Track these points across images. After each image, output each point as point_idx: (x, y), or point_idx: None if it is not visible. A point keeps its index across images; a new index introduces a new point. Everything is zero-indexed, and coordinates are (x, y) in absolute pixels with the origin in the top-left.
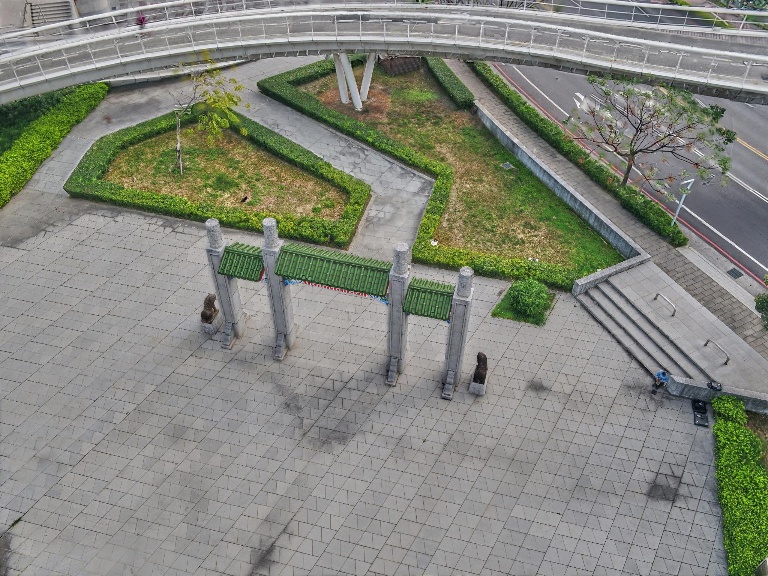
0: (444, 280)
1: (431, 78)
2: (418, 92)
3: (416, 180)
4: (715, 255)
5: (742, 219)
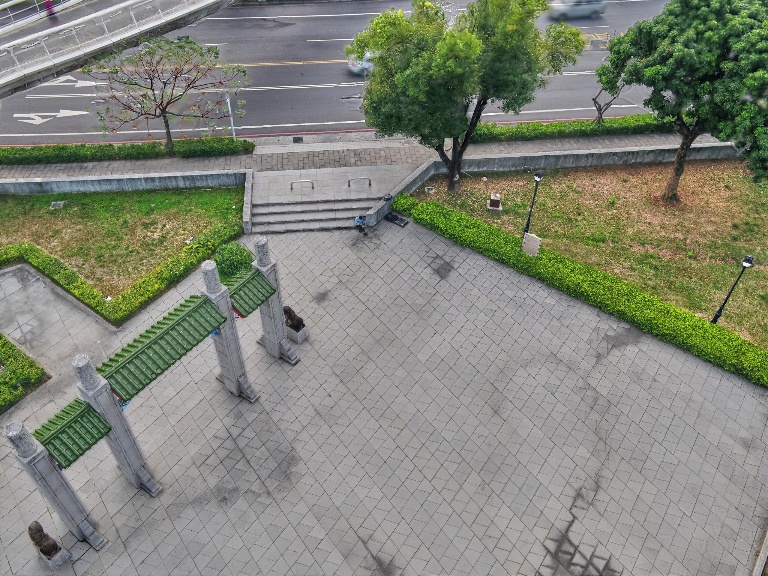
0: (162, 311)
1: None
2: None
3: (4, 279)
4: (274, 139)
5: (253, 109)
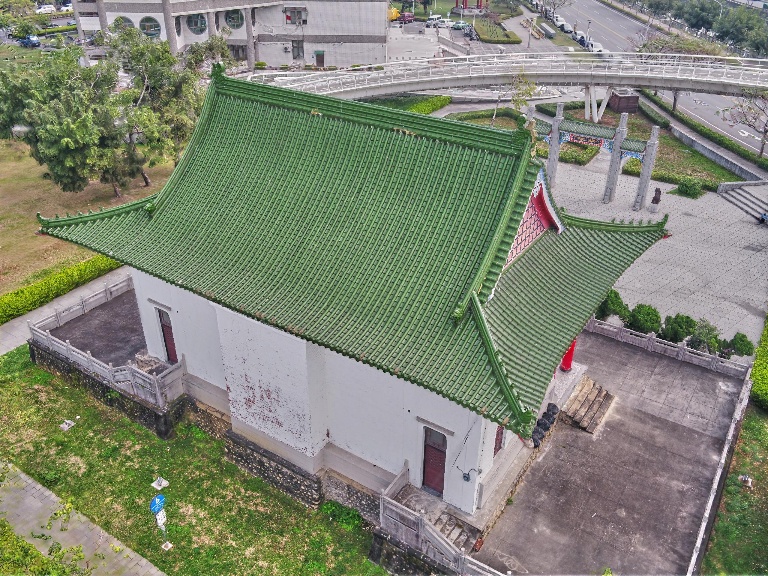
0: None
1: (643, 116)
2: (634, 120)
3: None
4: None
5: None
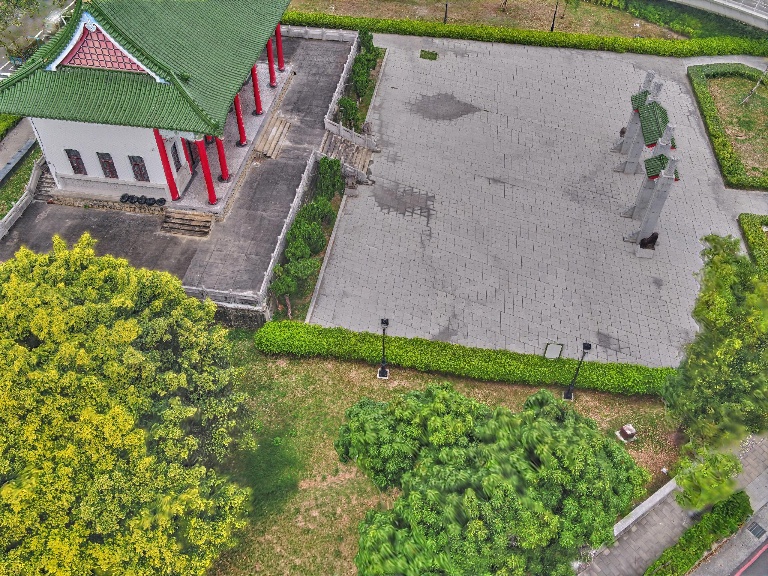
0: None
1: None
2: None
3: None
4: None
5: None
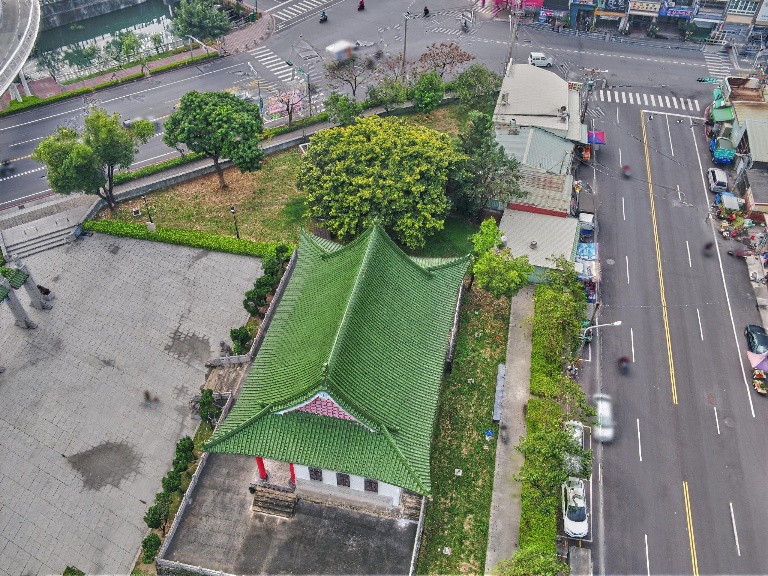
0: None
1: None
2: None
3: None
4: (7, 211)
5: None
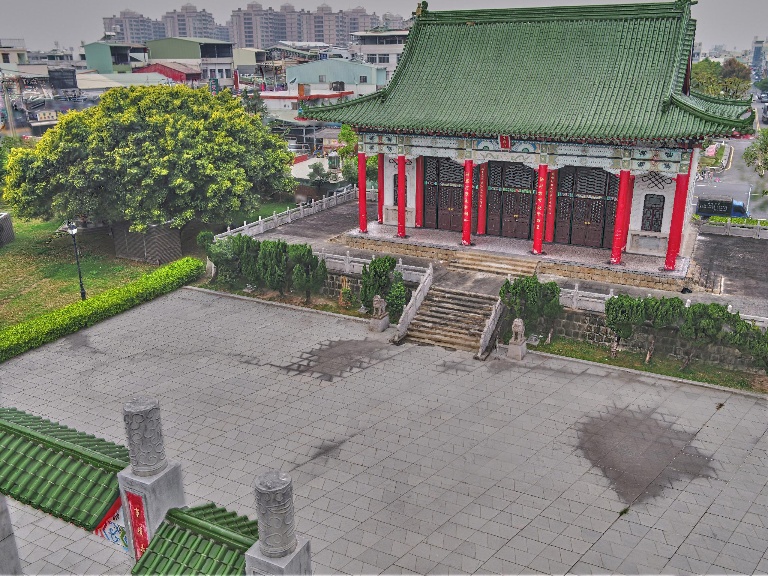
0: None
1: None
2: None
3: None
4: None
5: None
